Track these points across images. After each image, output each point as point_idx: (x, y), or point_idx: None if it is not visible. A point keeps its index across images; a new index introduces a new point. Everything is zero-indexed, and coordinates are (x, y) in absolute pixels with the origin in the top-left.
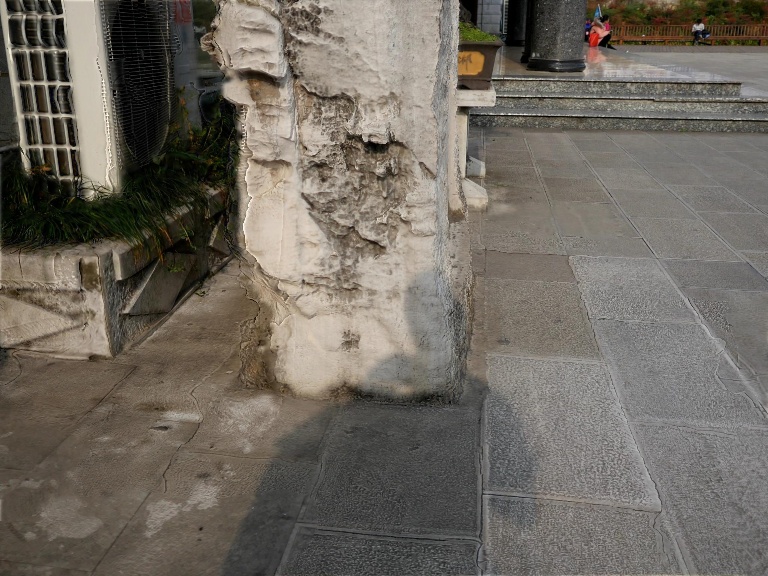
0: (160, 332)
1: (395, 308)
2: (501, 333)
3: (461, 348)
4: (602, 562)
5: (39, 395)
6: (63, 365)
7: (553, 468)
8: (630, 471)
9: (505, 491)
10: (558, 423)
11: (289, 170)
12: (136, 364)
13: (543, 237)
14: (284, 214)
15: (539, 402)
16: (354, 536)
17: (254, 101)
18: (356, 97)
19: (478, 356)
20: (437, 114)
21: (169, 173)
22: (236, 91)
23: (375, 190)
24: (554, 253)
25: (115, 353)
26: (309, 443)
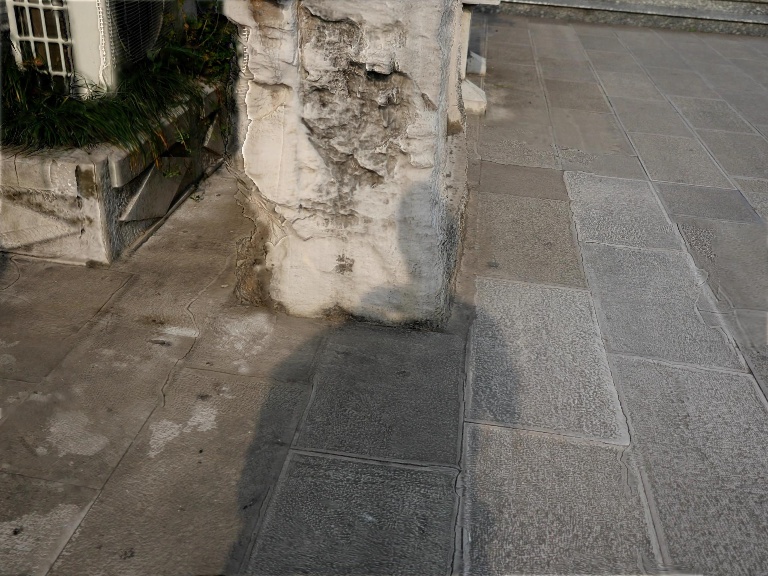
0: (155, 238)
1: (390, 236)
2: (491, 254)
3: (452, 271)
4: (570, 493)
5: (38, 301)
6: (60, 270)
7: (532, 398)
8: (604, 404)
9: (485, 419)
10: (540, 352)
11: (290, 94)
12: (132, 272)
13: (540, 148)
14: (284, 138)
15: (523, 329)
16: (342, 459)
17: (257, 23)
18: (361, 23)
19: (467, 278)
20: (443, 44)
21: (164, 71)
22: (238, 11)
23: (376, 119)
24: (549, 167)
25: (111, 259)
26: (301, 362)
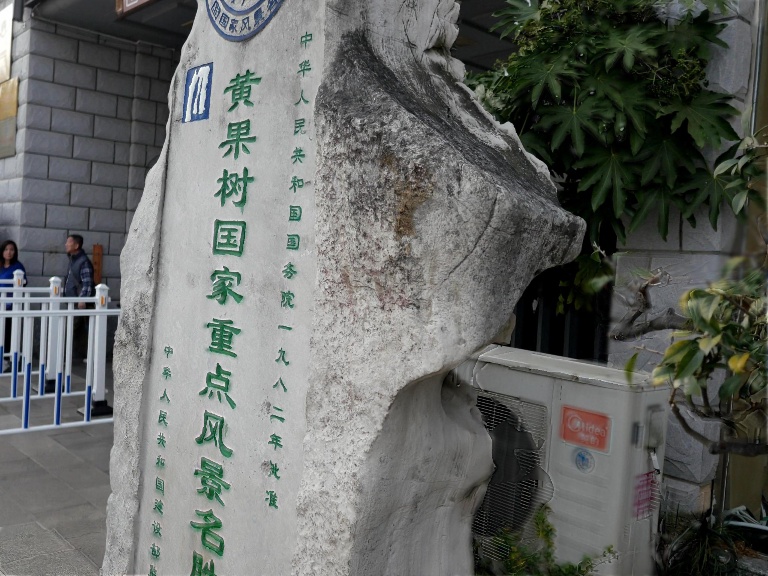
0: None
1: None
2: None
3: None
4: None
5: None
6: None
7: None
8: None
9: None
10: None
11: None
12: None
13: None
14: None
15: None
16: None
17: None
18: None
19: None
20: None
21: None
22: None
23: None
24: None
25: None
26: None
